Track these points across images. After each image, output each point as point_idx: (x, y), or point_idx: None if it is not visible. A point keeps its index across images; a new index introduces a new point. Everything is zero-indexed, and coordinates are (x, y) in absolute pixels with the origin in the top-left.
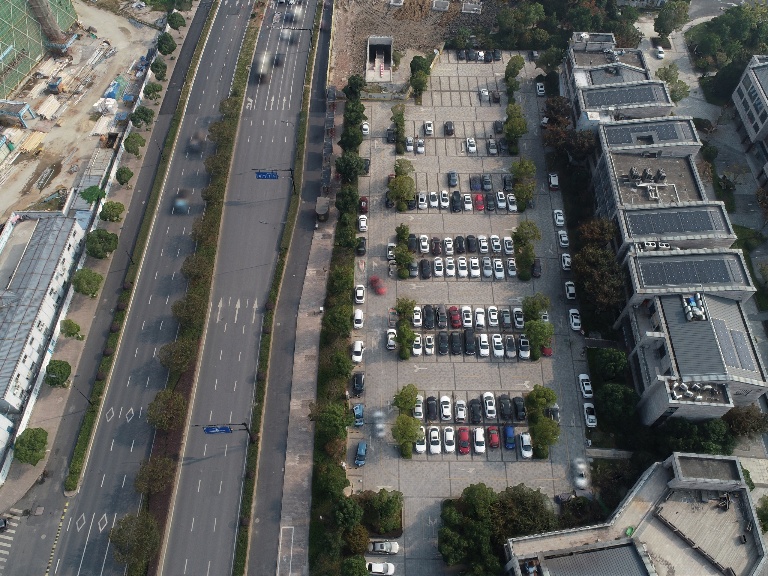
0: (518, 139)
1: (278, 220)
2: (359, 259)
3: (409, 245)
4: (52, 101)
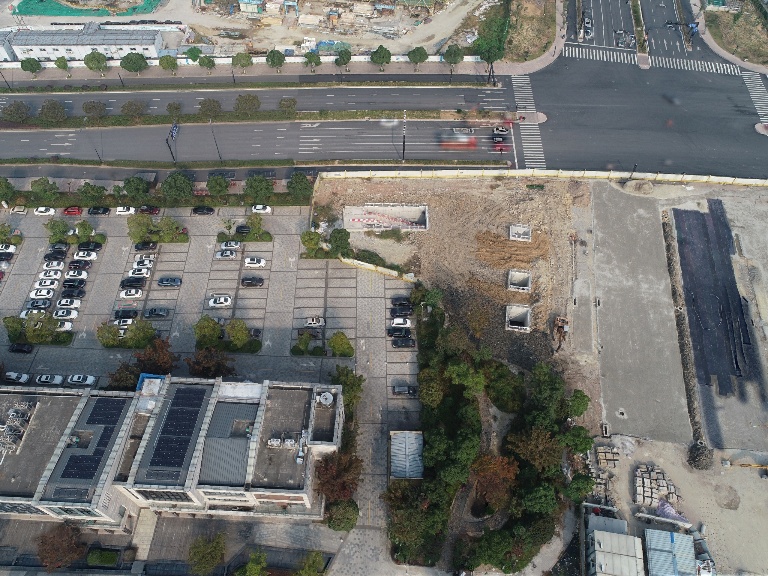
0: (226, 354)
1: (150, 158)
2: (86, 211)
3: (85, 243)
4: (316, 18)
